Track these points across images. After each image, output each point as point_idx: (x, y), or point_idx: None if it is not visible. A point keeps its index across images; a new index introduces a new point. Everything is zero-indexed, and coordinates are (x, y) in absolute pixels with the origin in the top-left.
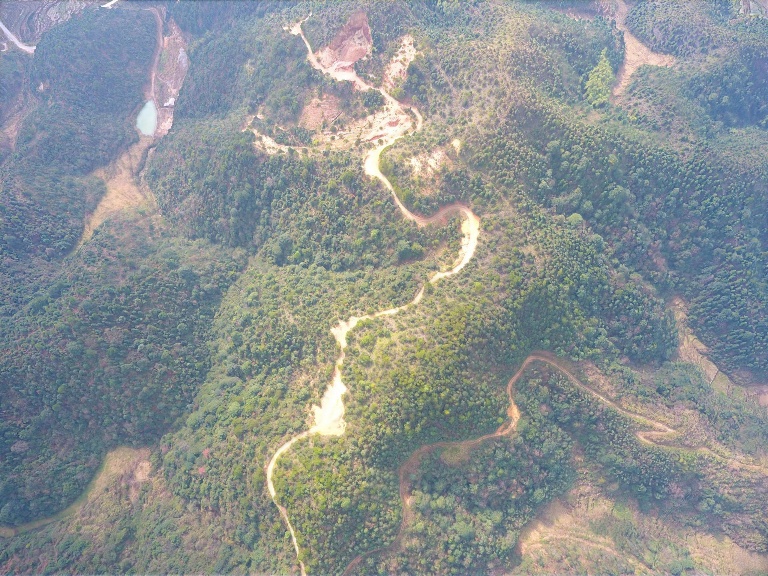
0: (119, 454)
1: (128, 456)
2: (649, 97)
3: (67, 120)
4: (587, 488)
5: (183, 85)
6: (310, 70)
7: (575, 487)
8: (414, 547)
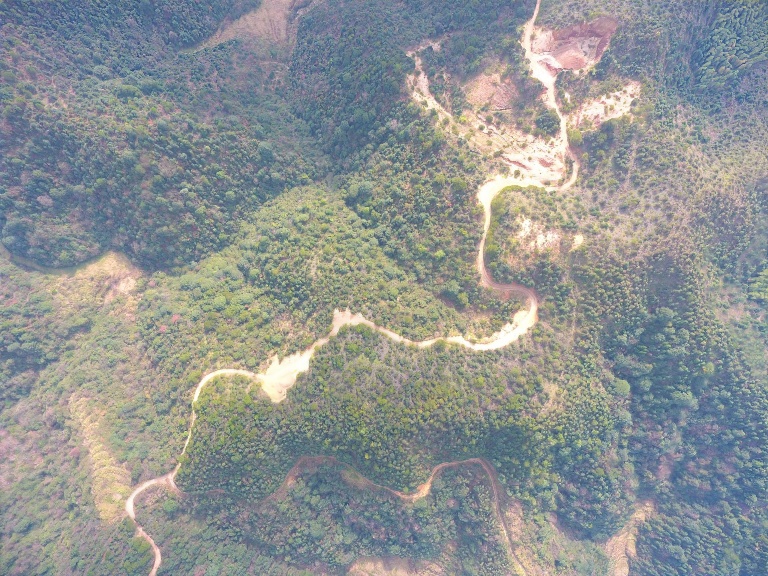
0: (118, 258)
1: (124, 265)
2: None
3: None
4: (438, 569)
5: None
6: (515, 43)
7: (430, 561)
8: (268, 516)
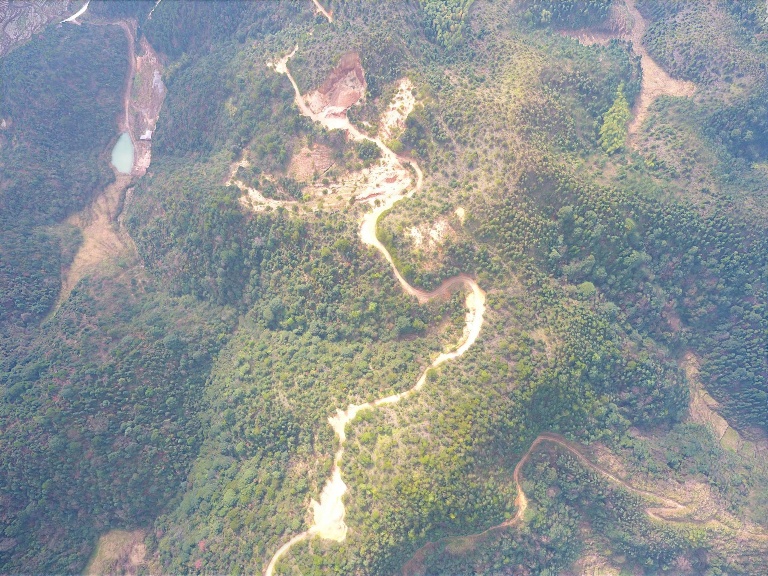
0: (112, 537)
1: (122, 539)
2: (668, 139)
3: (34, 164)
4: (593, 558)
5: (160, 117)
6: (298, 117)
7: (581, 557)
8: None
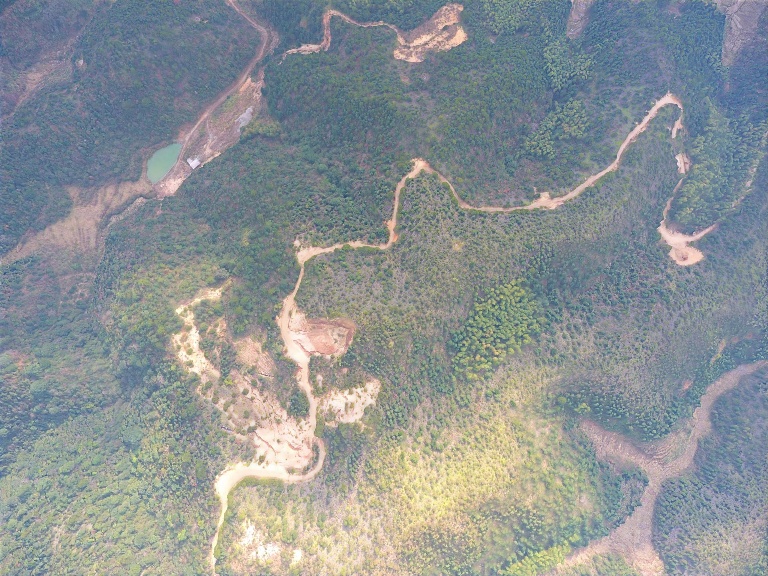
0: None
1: None
2: None
3: (71, 127)
4: None
5: (211, 162)
6: (270, 322)
7: None
8: None
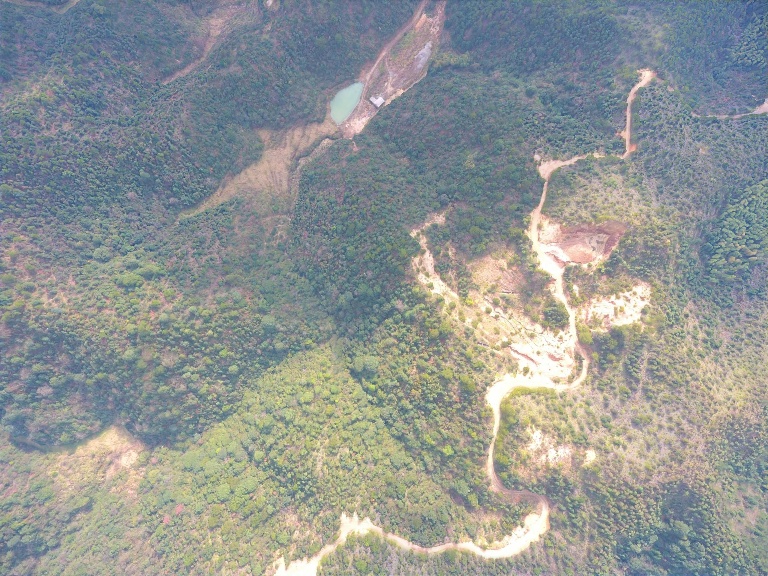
0: (120, 432)
1: (125, 438)
2: None
3: (269, 66)
4: None
5: (401, 97)
6: (522, 235)
7: None
8: None
